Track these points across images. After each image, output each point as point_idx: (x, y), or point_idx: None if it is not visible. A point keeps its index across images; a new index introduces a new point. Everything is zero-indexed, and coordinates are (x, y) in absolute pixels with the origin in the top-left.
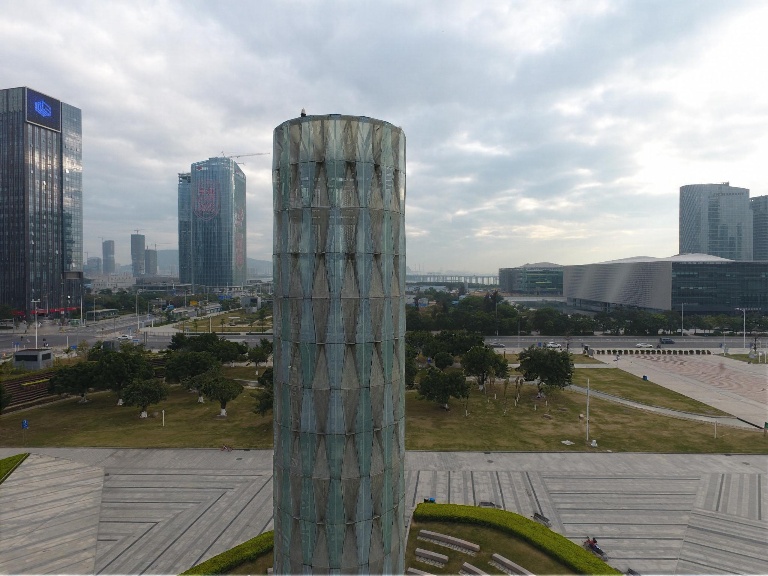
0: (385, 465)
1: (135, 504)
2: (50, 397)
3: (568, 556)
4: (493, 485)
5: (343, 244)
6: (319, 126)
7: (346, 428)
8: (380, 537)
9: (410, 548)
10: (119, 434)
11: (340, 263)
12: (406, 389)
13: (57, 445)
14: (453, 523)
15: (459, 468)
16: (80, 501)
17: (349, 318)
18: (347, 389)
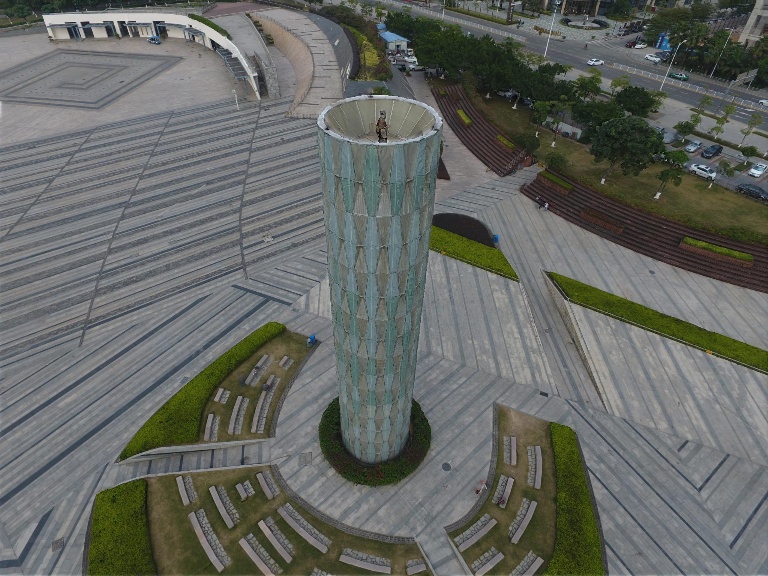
0: None
1: (760, 493)
2: None
3: None
4: None
5: None
6: None
7: None
8: None
9: None
10: None
11: None
12: None
13: None
14: None
15: None
16: None
17: None
18: None
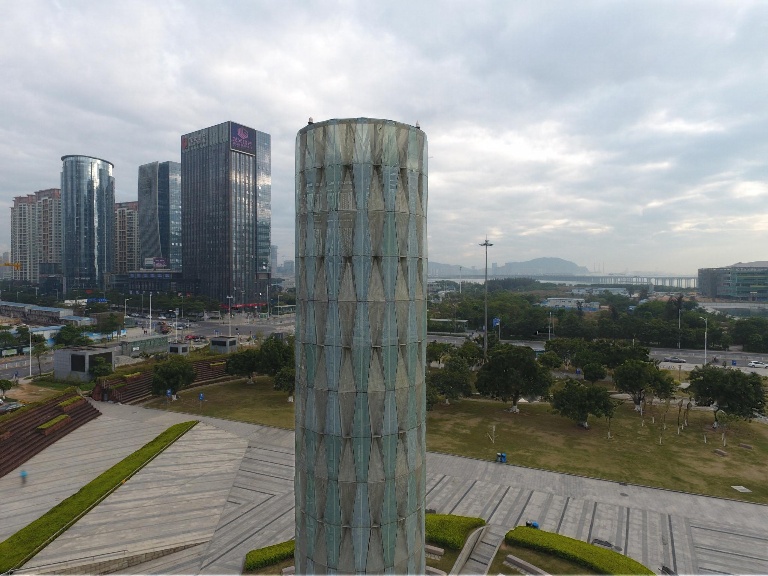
0: (386, 474)
1: (262, 476)
2: (228, 377)
3: None
4: (619, 523)
5: (340, 247)
6: (322, 132)
7: (344, 431)
8: (380, 548)
9: (493, 571)
10: (268, 414)
11: (338, 266)
12: (545, 401)
13: (222, 417)
14: (548, 555)
15: (581, 496)
16: (224, 466)
17: (347, 321)
18: (344, 392)
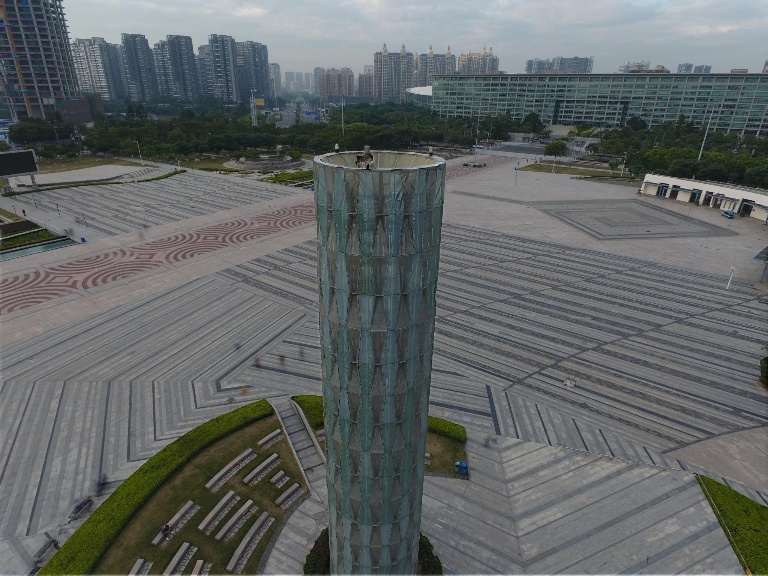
0: None
1: None
2: None
3: (78, 572)
4: None
5: None
6: None
7: None
8: None
9: None
10: None
11: None
12: None
13: None
14: None
15: None
16: None
17: None
18: None
